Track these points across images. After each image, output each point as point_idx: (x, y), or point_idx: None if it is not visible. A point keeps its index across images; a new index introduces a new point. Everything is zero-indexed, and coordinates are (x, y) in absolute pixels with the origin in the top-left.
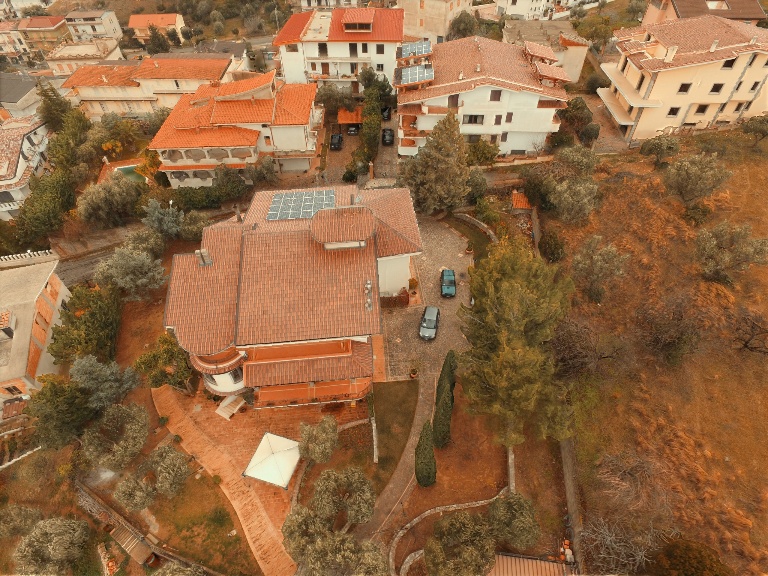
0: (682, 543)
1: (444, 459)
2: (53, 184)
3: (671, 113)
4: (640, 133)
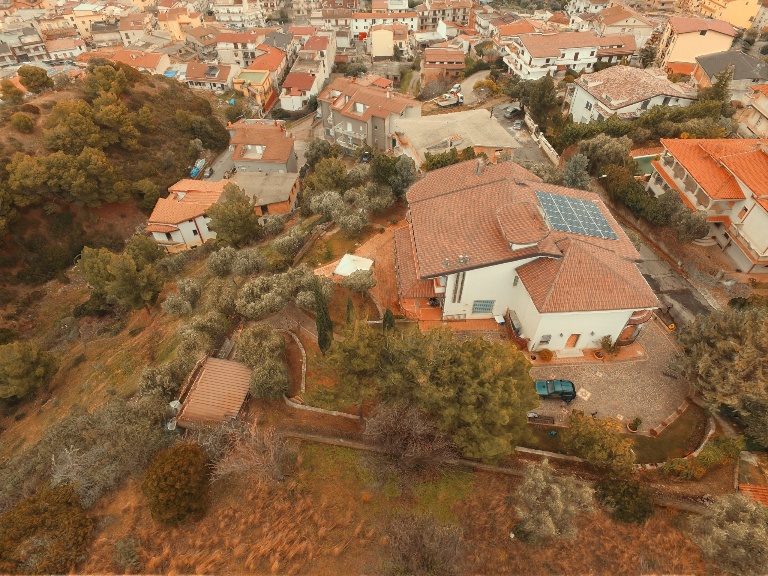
0: (196, 460)
1: None
2: (610, 124)
3: None
4: None
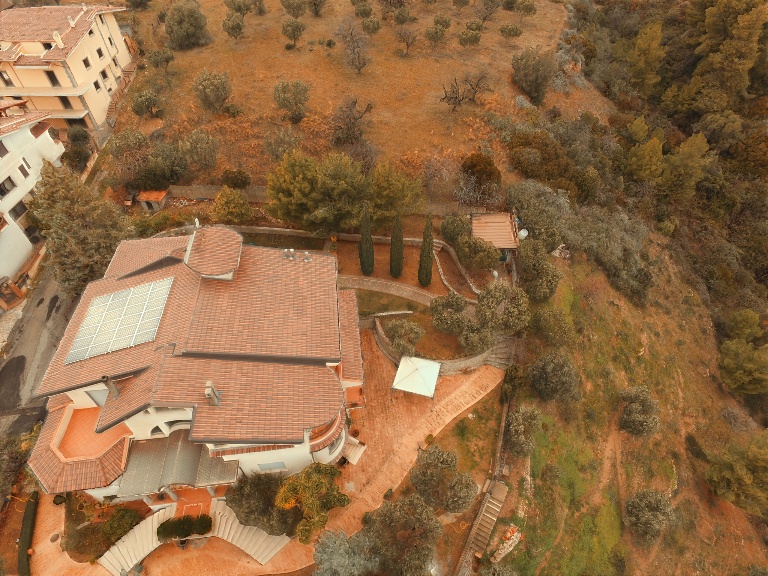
0: (470, 160)
1: (407, 275)
2: None
3: (96, 88)
4: (97, 116)
